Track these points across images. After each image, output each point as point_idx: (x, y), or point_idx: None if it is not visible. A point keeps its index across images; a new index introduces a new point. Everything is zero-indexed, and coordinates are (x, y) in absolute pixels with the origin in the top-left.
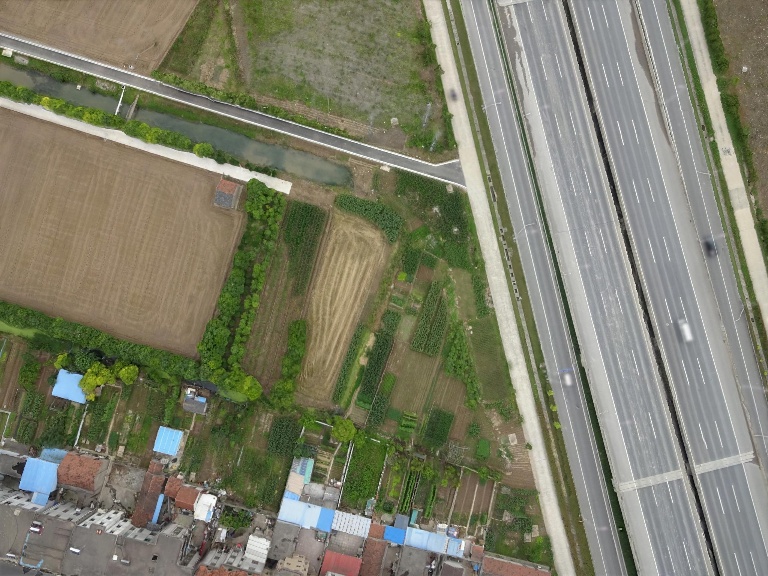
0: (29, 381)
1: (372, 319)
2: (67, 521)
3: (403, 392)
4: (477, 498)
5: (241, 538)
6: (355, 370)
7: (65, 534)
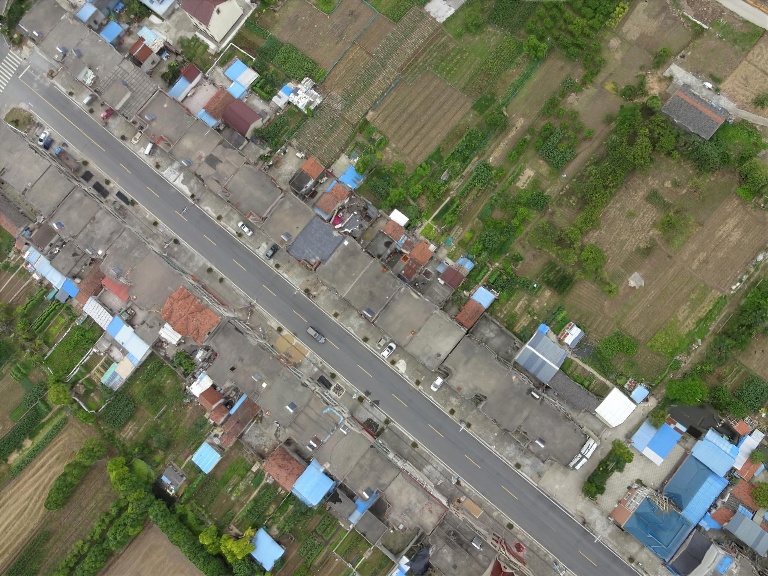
0: (300, 574)
1: (2, 476)
2: (290, 436)
3: (11, 400)
4: (3, 285)
5: (193, 343)
6: (39, 438)
7: (296, 426)
